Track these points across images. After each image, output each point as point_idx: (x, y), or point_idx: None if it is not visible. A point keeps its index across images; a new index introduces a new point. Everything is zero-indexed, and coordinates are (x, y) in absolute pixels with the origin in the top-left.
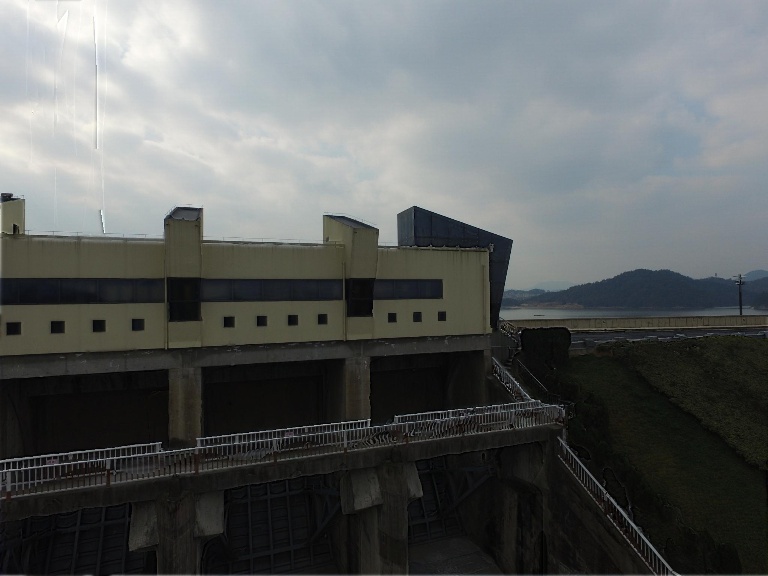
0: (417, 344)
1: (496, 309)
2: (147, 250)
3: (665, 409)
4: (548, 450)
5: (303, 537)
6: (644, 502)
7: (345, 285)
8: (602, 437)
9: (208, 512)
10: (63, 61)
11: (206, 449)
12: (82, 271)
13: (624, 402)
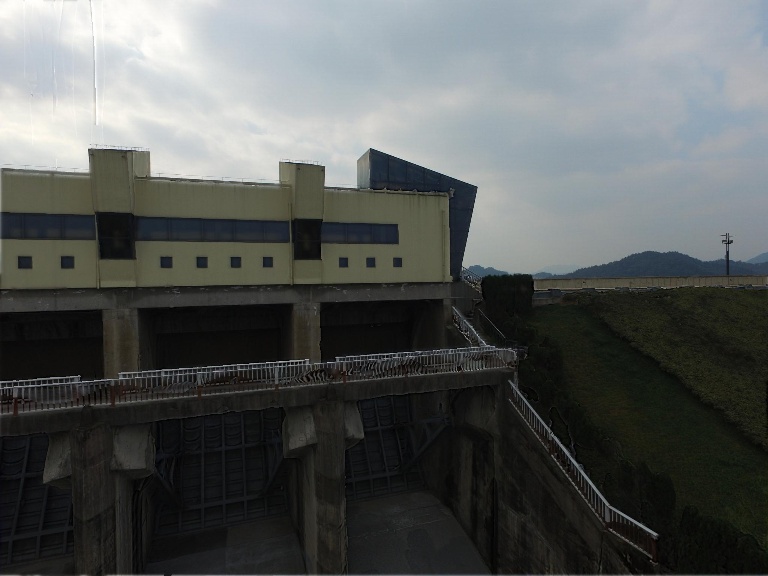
0: (371, 291)
1: (459, 258)
2: (75, 185)
3: (625, 354)
4: (499, 394)
5: (259, 489)
6: (584, 437)
7: (292, 227)
8: (555, 380)
9: (129, 447)
10: (61, 41)
11: (123, 381)
12: (5, 205)
13: (583, 348)
